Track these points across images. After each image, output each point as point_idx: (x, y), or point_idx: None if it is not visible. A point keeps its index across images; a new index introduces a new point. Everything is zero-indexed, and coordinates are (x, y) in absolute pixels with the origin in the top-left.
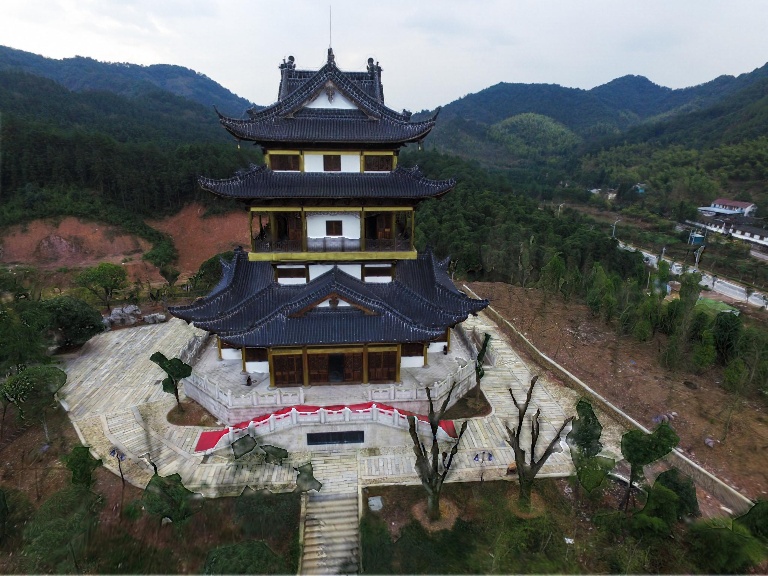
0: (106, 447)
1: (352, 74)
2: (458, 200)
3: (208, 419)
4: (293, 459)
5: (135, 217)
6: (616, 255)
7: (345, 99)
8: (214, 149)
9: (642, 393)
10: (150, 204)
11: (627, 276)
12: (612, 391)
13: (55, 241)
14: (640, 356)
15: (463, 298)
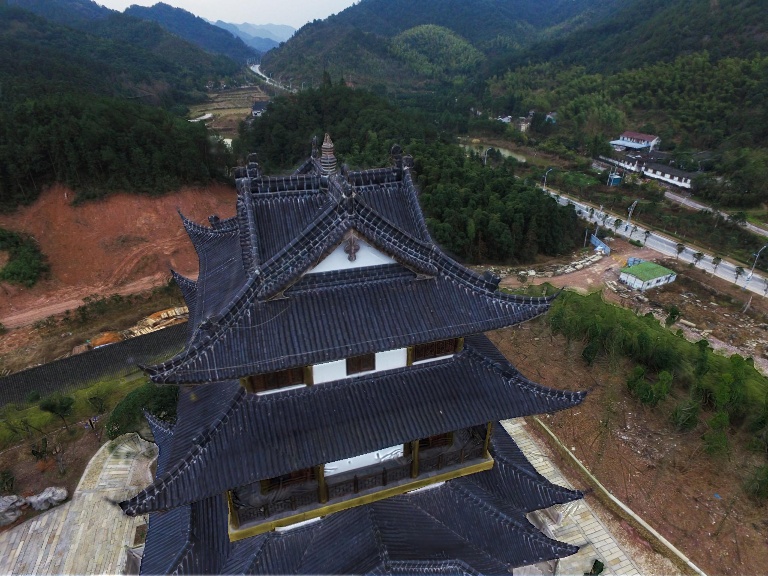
0: None
1: (366, 175)
2: (384, 153)
3: None
4: None
5: None
6: (558, 217)
7: (376, 251)
8: (70, 106)
9: (758, 569)
10: None
11: (566, 235)
12: (721, 567)
13: None
14: (718, 480)
15: (540, 482)
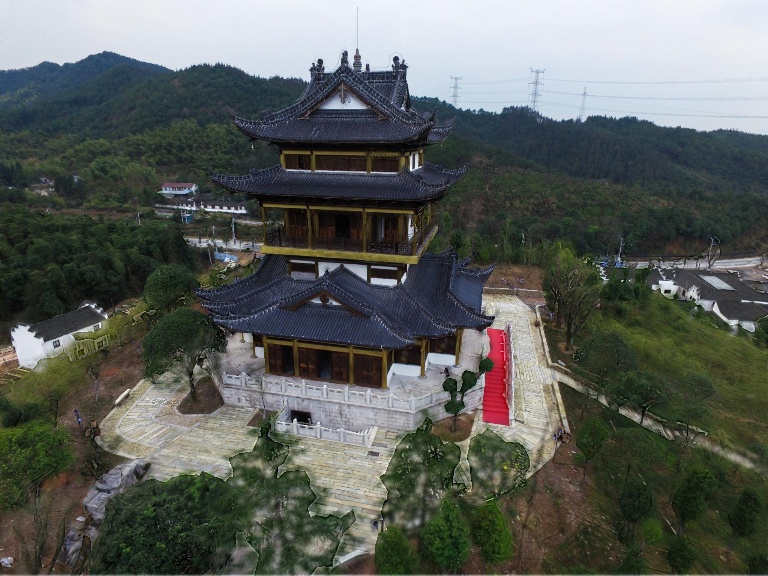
0: None
1: None
2: None
3: (465, 417)
4: (519, 385)
5: None
6: None
7: None
8: None
9: None
10: None
11: None
12: None
13: None
14: None
15: None
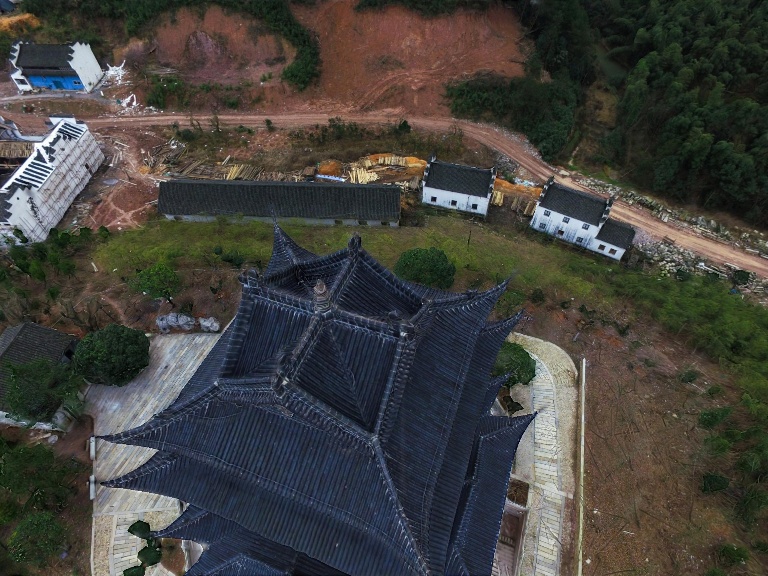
0: (104, 575)
1: (359, 321)
2: (741, 6)
3: None
4: None
5: (281, 5)
6: None
7: None
8: None
9: None
10: None
11: None
12: None
13: (202, 38)
14: None
15: None
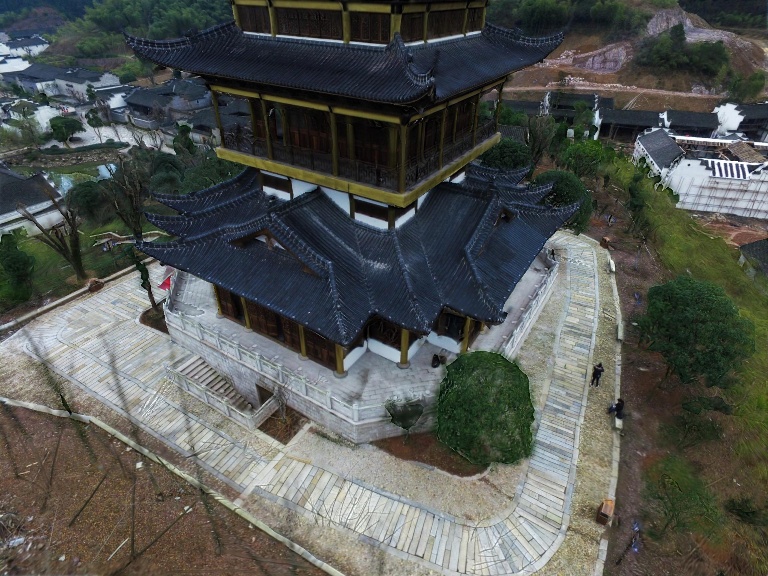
0: None
1: None
2: None
3: None
4: None
5: None
6: None
7: None
8: None
9: None
10: None
11: None
12: None
13: None
14: None
15: None
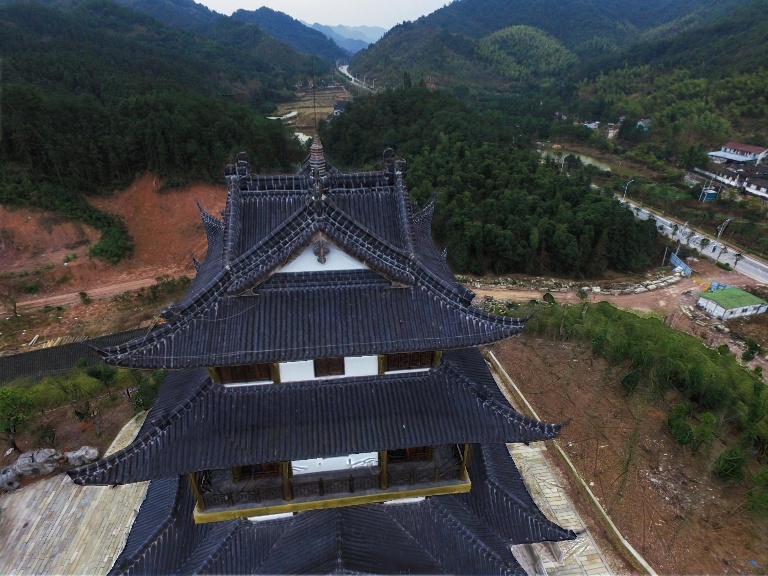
0: None
1: (356, 178)
2: (453, 156)
3: None
4: None
5: (76, 197)
6: (633, 231)
7: None
8: (166, 102)
9: None
10: (94, 177)
11: (641, 252)
12: None
13: None
14: (759, 544)
15: (532, 514)
